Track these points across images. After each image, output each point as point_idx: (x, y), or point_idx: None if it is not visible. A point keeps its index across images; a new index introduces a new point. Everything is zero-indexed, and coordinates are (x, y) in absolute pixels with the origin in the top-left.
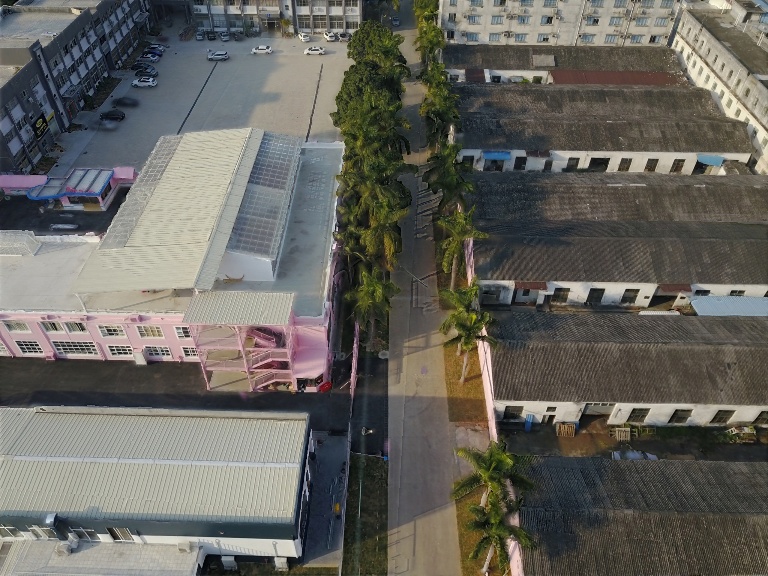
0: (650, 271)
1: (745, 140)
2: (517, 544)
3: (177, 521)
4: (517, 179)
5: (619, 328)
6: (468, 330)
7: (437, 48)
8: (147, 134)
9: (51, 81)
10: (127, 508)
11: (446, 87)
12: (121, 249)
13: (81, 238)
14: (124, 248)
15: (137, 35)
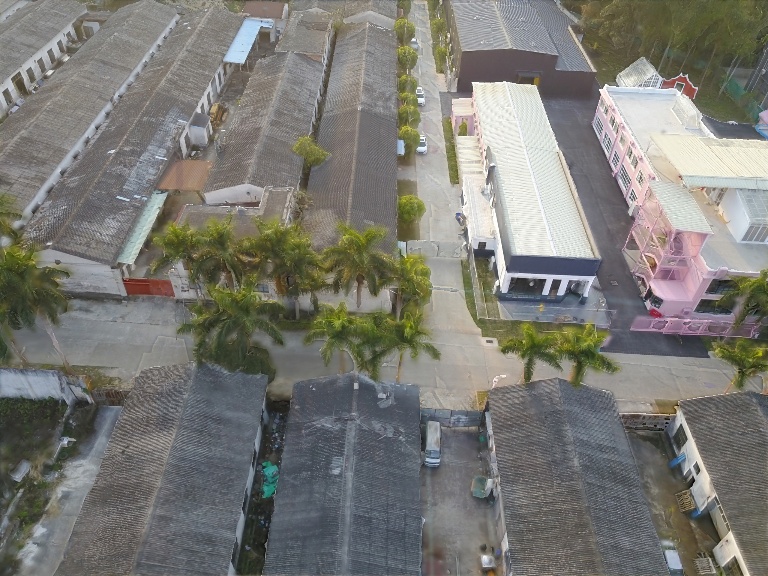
0: None
1: None
2: None
3: None
4: None
5: None
6: None
7: None
8: None
9: None
10: (507, 193)
11: None
12: (704, 145)
13: None
14: (706, 146)
15: None
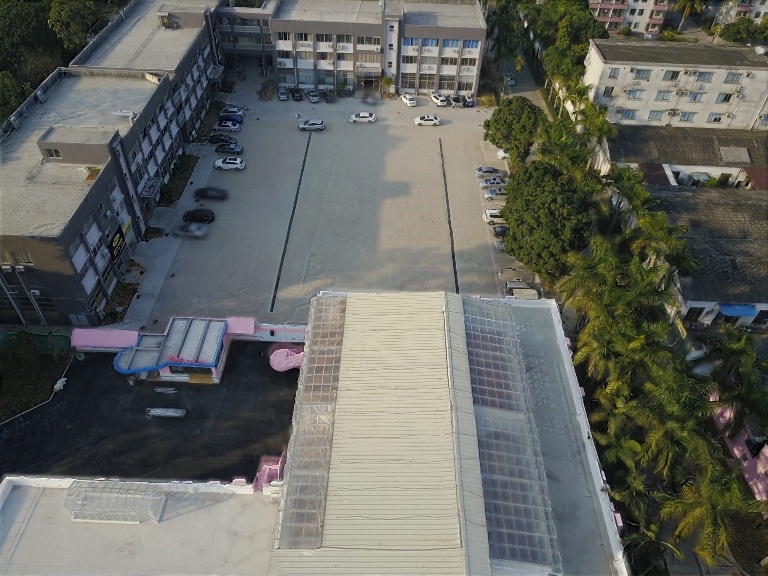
0: None
1: None
2: None
3: None
4: None
5: None
6: None
7: (606, 136)
8: (247, 244)
9: (129, 180)
10: None
11: (650, 204)
12: (318, 553)
13: (225, 488)
14: (322, 551)
15: (209, 94)
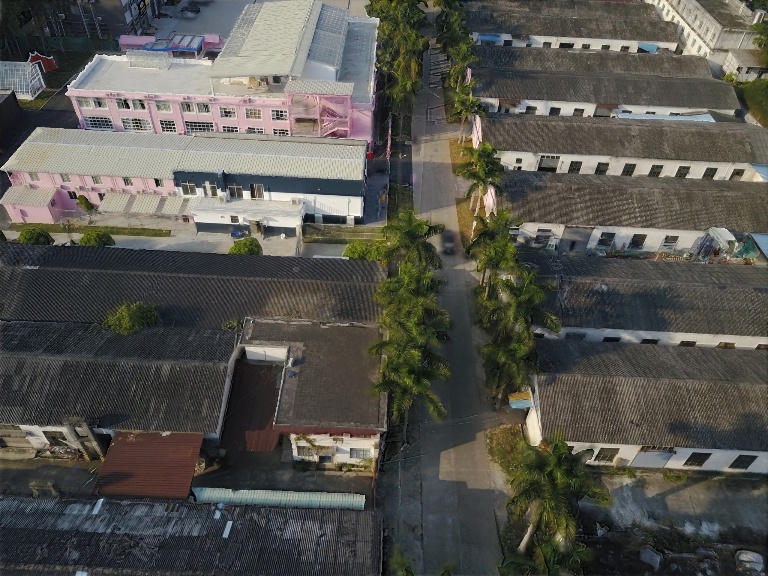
0: (591, 95)
1: (674, 33)
2: (493, 207)
3: (294, 177)
4: (504, 47)
5: (566, 119)
6: (467, 106)
7: None
8: (219, 23)
9: None
10: (262, 174)
11: None
12: (235, 57)
13: (199, 61)
14: (237, 57)
15: None
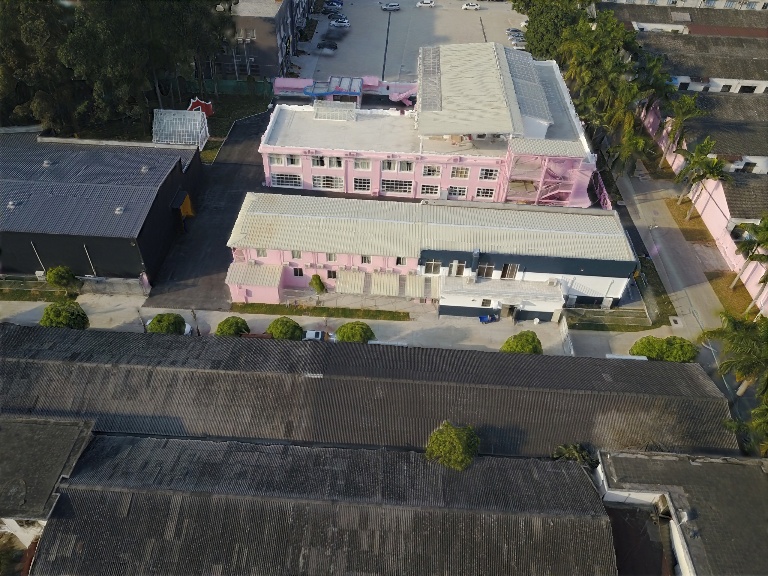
0: None
1: None
2: None
3: (559, 257)
4: None
5: None
6: (711, 169)
7: (594, 2)
8: (360, 60)
9: None
10: (518, 252)
11: None
12: (441, 111)
13: (386, 112)
14: (443, 111)
15: None
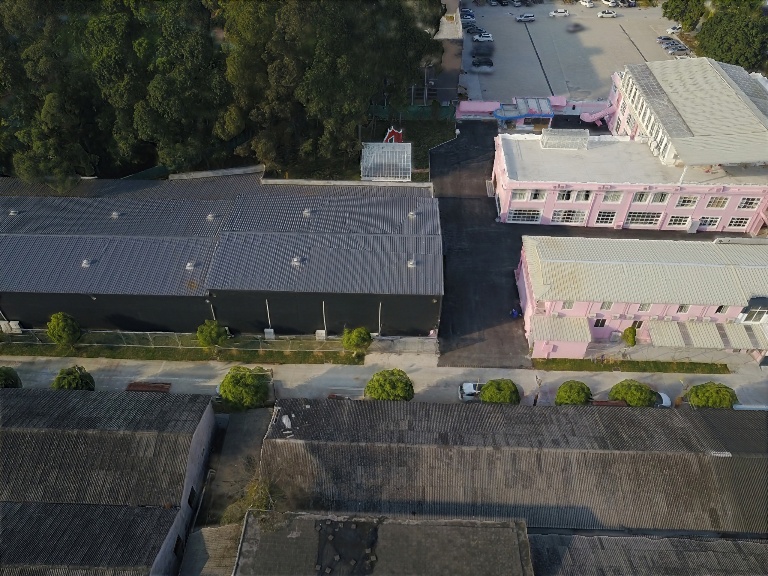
0: None
1: None
2: None
3: None
4: None
5: None
6: None
7: None
8: (521, 77)
9: None
10: None
11: None
12: (694, 137)
13: (615, 138)
14: (696, 137)
15: None
